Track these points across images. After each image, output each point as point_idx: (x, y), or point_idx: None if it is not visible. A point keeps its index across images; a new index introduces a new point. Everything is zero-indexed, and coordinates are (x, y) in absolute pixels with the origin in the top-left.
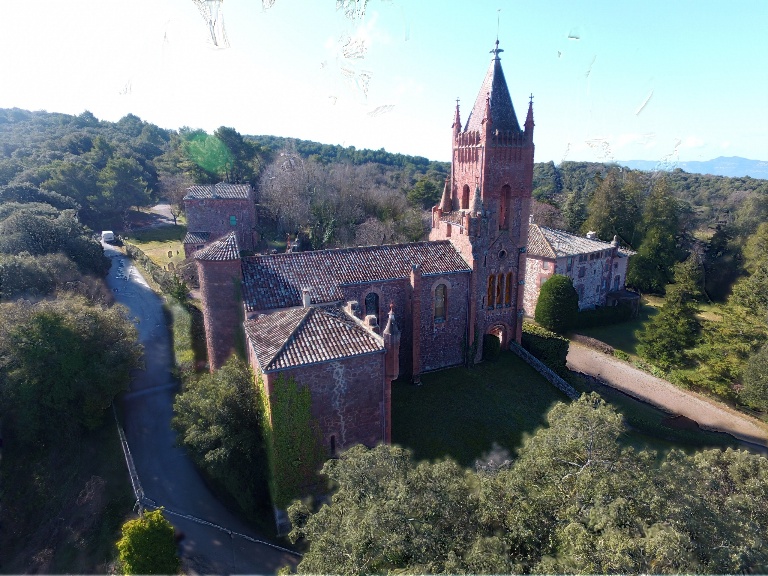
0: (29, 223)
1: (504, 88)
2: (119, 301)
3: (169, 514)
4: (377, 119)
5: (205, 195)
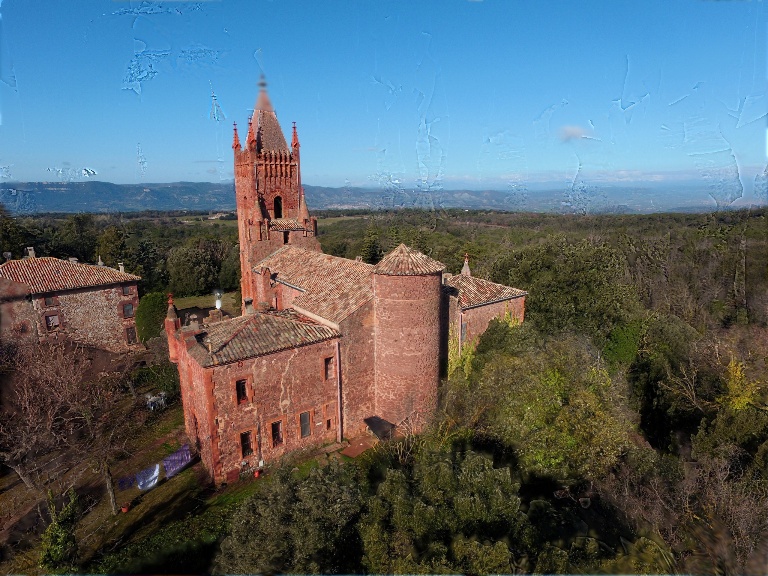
0: None
1: None
2: None
3: None
4: None
5: None
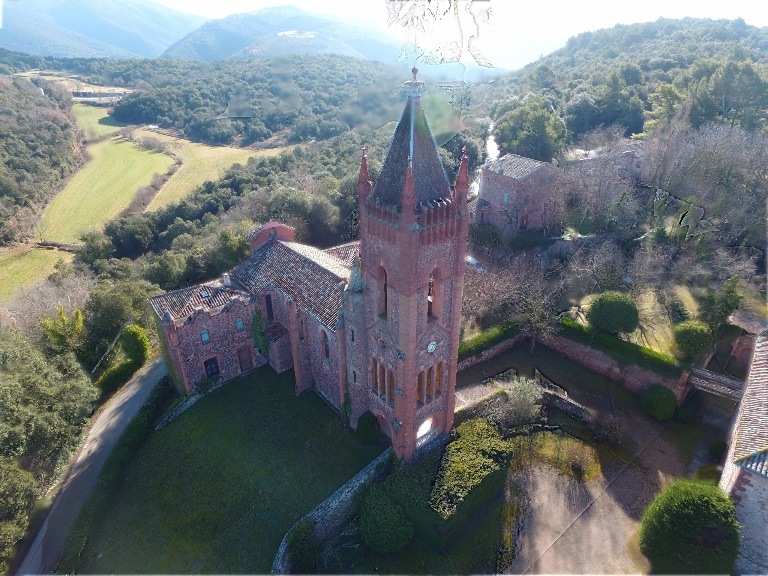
0: None
1: (407, 139)
2: None
3: None
4: None
5: (498, 167)
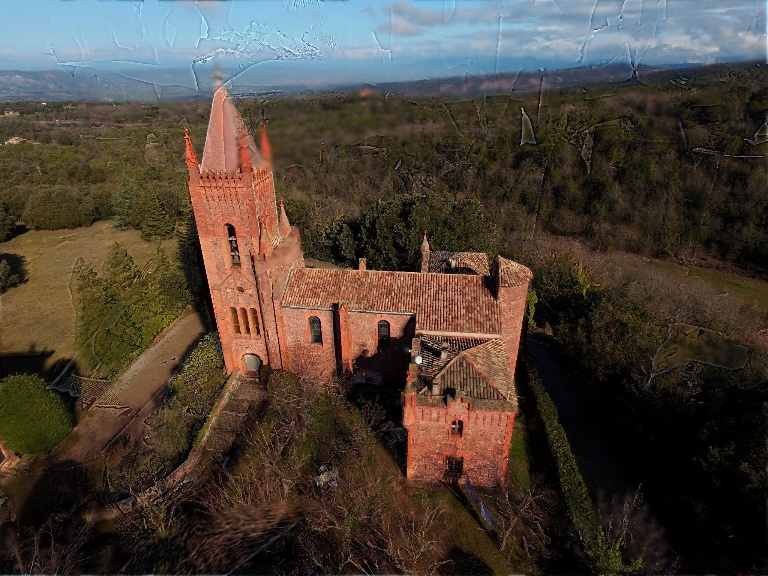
0: None
1: None
2: None
3: (528, 342)
4: None
5: None
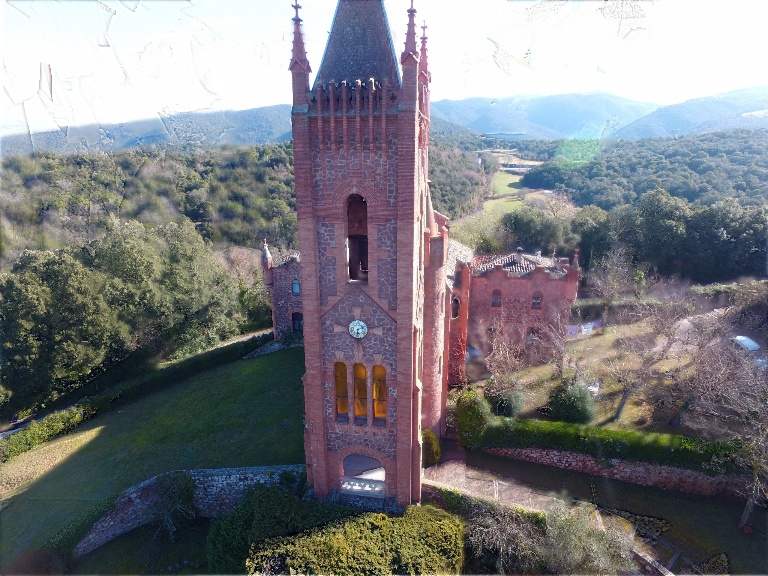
0: (649, 200)
1: None
2: (656, 292)
3: None
4: (524, 74)
5: None
